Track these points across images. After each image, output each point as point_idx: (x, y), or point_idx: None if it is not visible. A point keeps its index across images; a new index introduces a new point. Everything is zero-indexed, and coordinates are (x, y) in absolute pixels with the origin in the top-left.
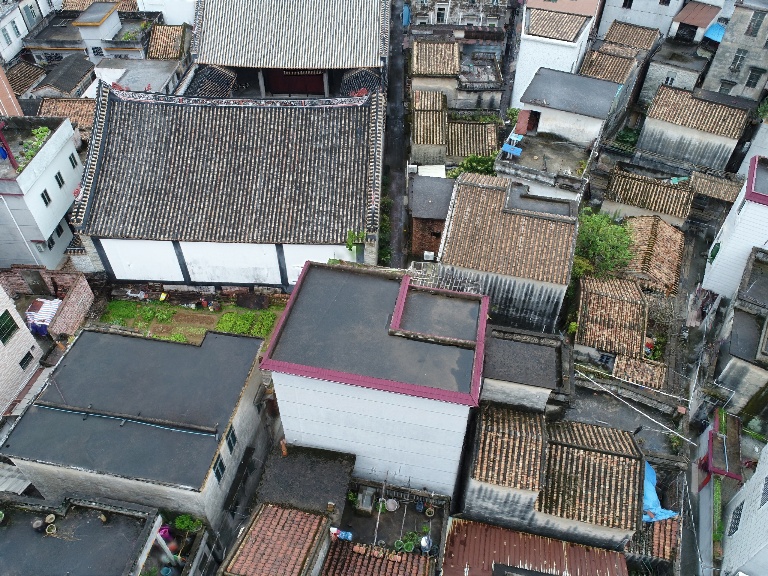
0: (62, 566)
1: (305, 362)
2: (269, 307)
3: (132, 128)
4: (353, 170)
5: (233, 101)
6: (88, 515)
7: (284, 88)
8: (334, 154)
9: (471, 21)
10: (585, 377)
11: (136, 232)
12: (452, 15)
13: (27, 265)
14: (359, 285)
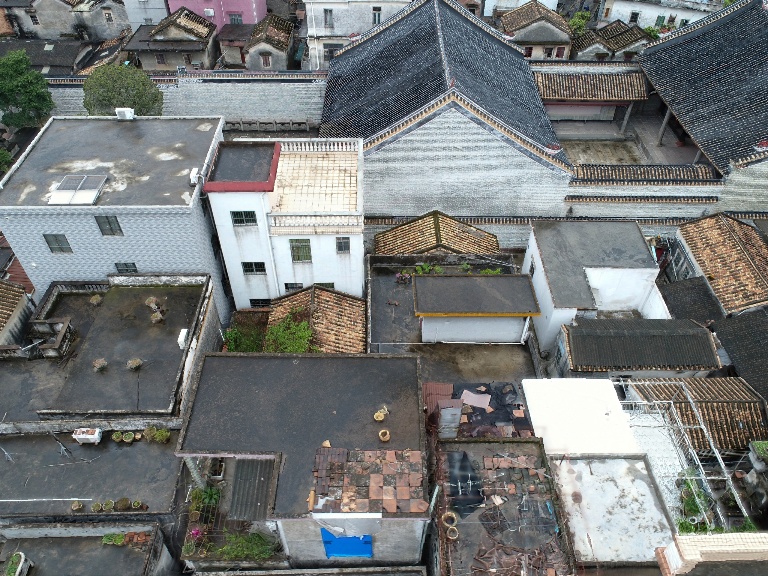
0: None
1: None
2: None
3: None
4: None
5: None
6: None
7: None
8: None
9: None
10: None
11: None
12: None
13: None
14: None
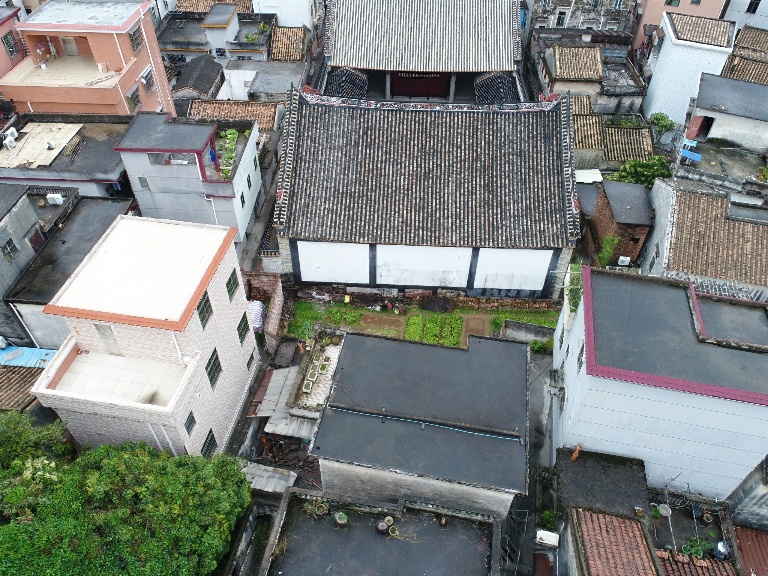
0: (417, 568)
1: (630, 368)
2: (453, 310)
3: (321, 131)
4: (545, 175)
5: (421, 105)
6: (423, 518)
7: (406, 91)
8: (524, 159)
9: (591, 25)
10: None
11: (335, 235)
12: (572, 19)
13: None
14: (646, 291)
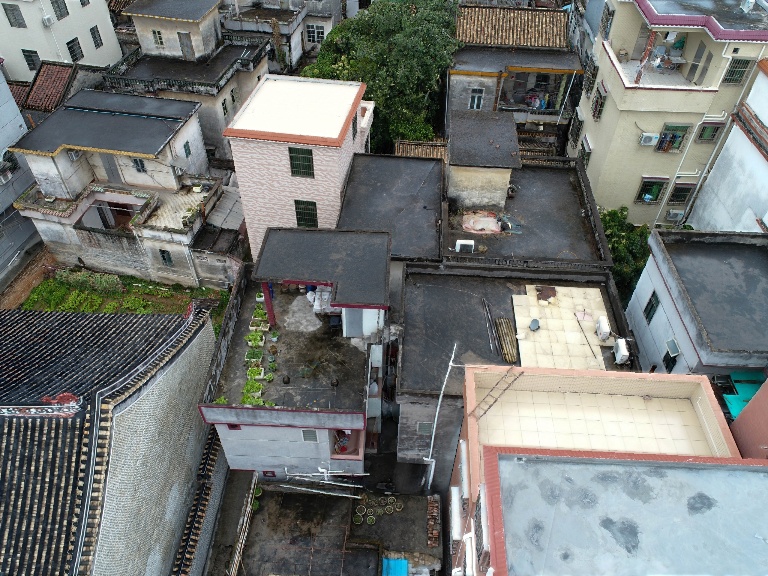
0: None
1: None
2: None
3: None
4: None
5: None
6: None
7: None
8: None
9: None
10: None
11: None
12: None
13: None
14: None
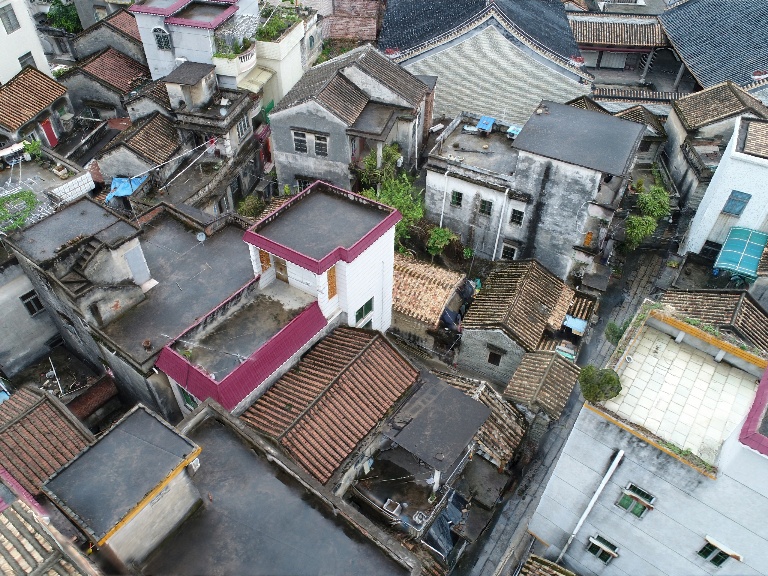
0: None
1: None
2: None
3: None
4: None
5: None
6: None
7: None
8: None
9: None
10: None
11: None
12: None
13: (379, 1)
14: None
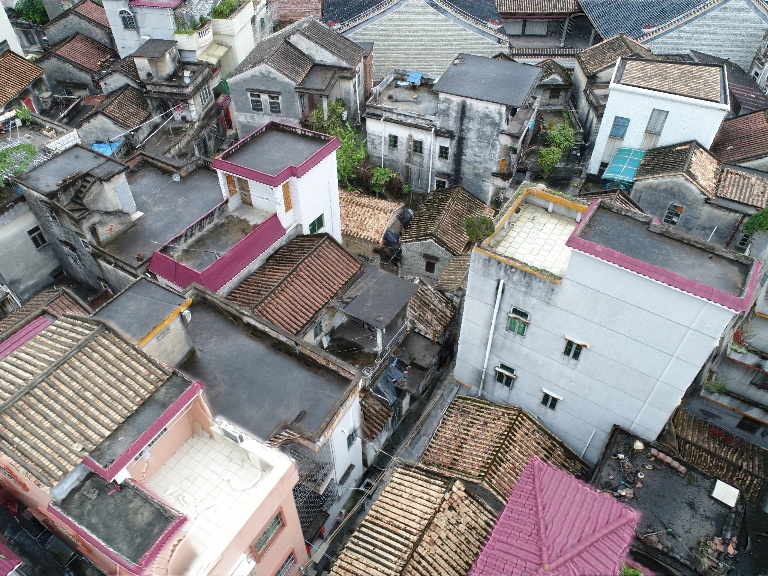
0: None
1: None
2: None
3: None
4: None
5: None
6: None
7: None
8: None
9: None
10: (185, 127)
11: None
12: None
13: None
14: None
